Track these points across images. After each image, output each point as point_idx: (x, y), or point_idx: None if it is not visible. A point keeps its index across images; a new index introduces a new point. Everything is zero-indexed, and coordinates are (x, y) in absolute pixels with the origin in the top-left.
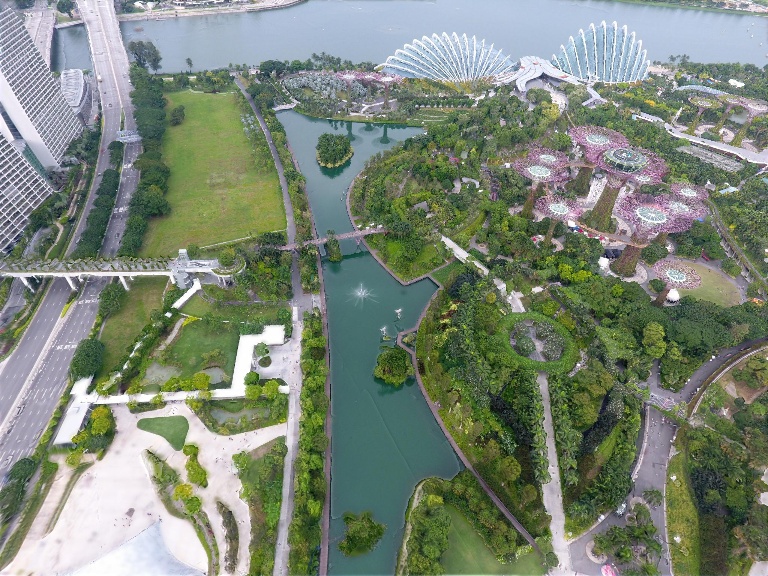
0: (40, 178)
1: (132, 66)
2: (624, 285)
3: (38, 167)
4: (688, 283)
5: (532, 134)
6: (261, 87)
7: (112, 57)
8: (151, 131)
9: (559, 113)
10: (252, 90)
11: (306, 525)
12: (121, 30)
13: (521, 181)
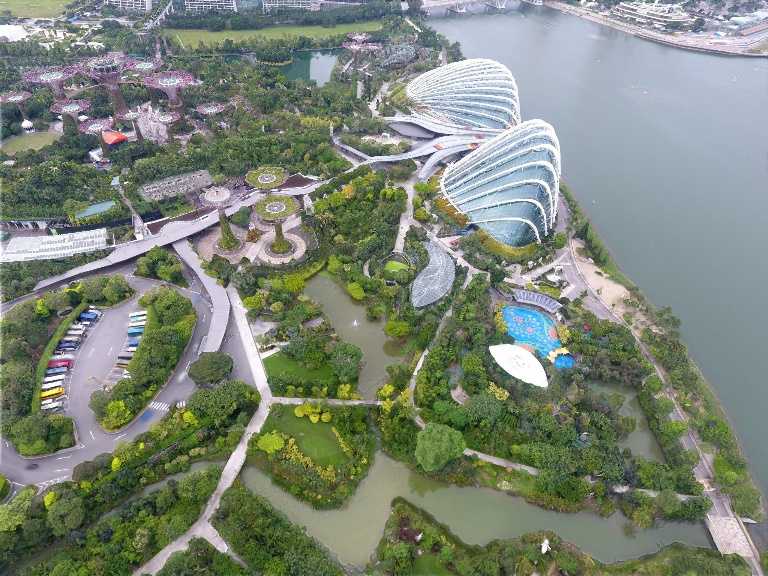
0: (232, 0)
1: (396, 3)
2: (41, 102)
3: (257, 4)
4: (6, 100)
5: (263, 106)
6: (373, 33)
7: (429, 3)
8: (293, 15)
9: (313, 125)
10: (369, 32)
11: (5, 48)
12: (542, 12)
13: (193, 100)
